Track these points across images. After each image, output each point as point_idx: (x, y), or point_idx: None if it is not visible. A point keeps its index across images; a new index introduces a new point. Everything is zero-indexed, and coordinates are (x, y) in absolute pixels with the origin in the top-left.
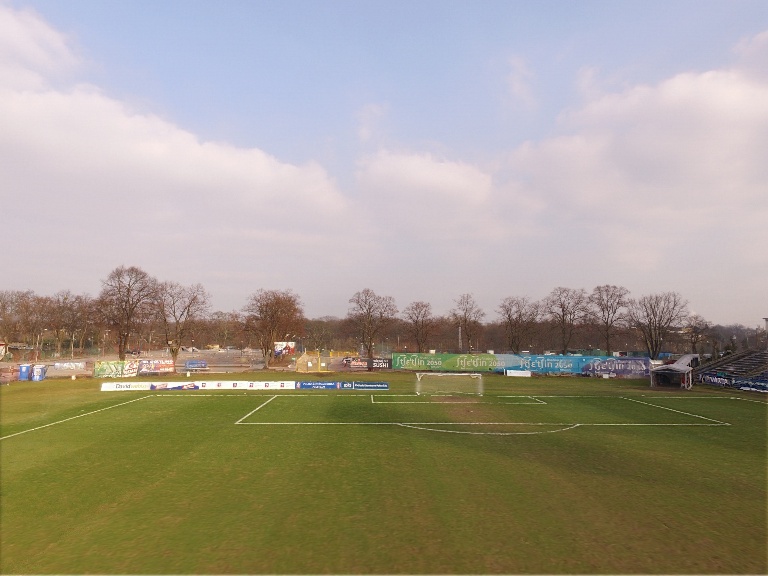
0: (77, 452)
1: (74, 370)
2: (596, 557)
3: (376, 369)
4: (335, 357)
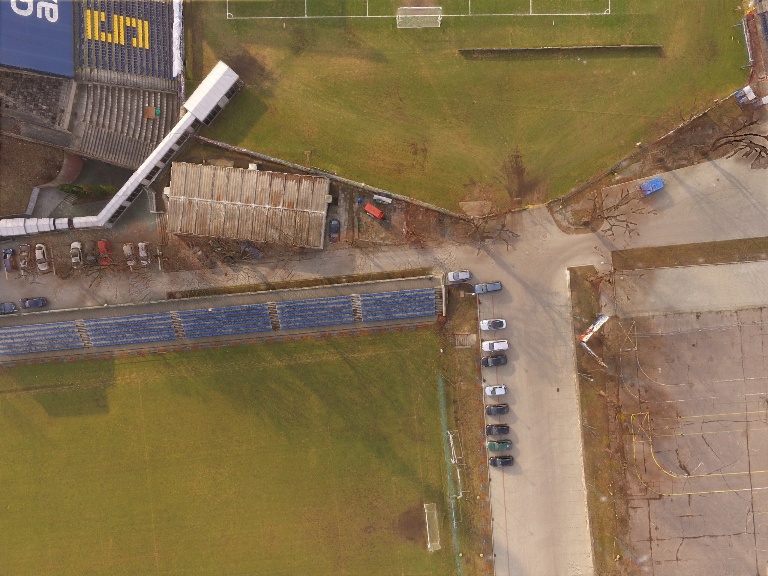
0: None
1: (764, 177)
2: None
3: None
4: None
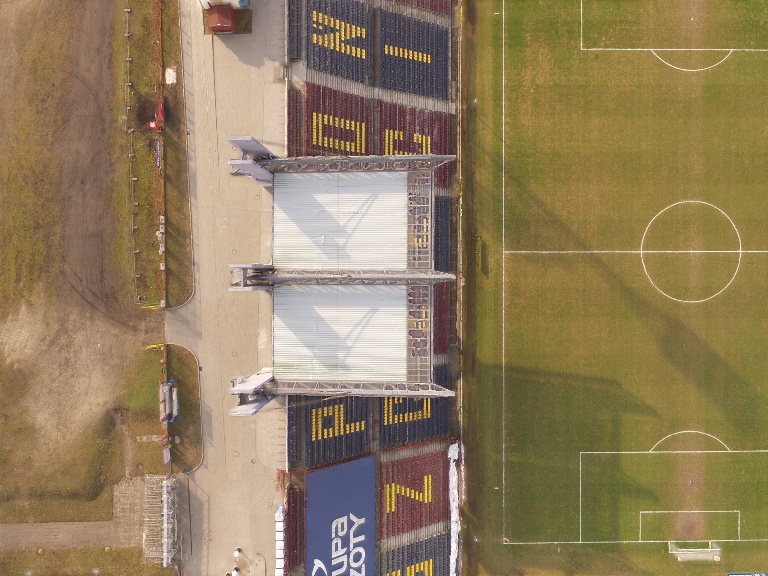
0: None
1: None
2: (705, 332)
3: None
4: None
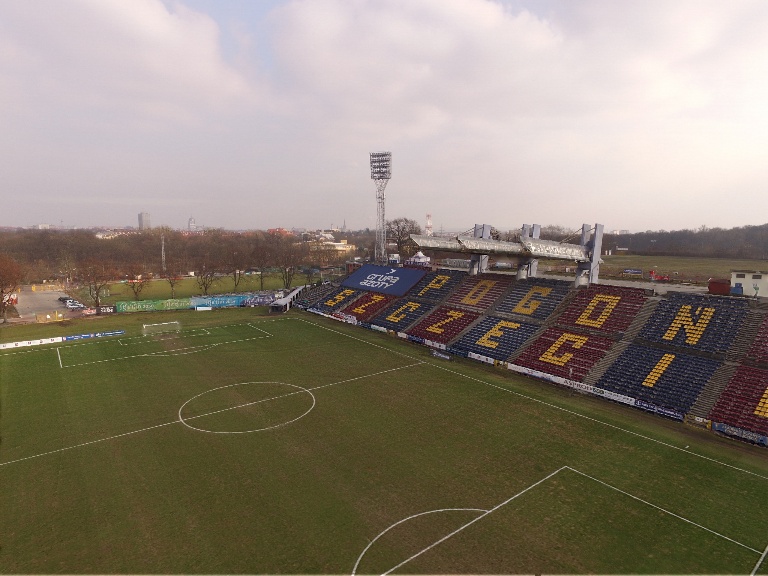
0: (11, 389)
1: None
2: None
3: (104, 314)
4: (40, 292)
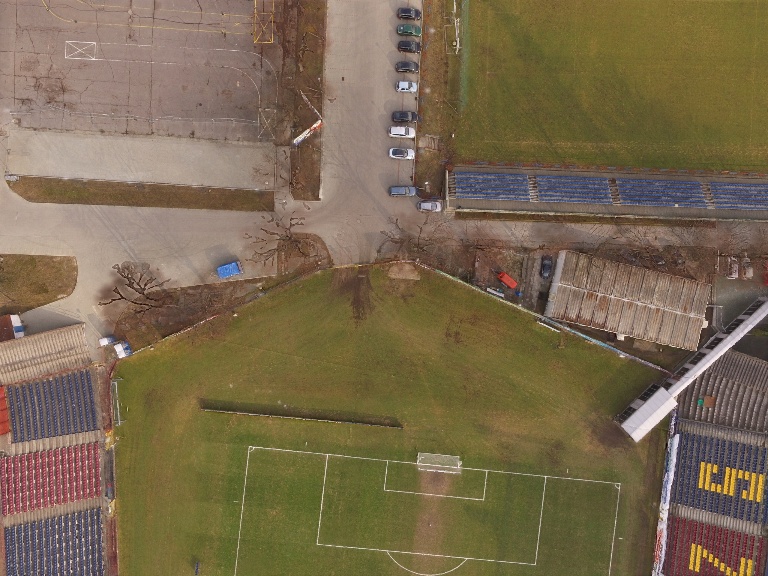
0: None
1: (111, 266)
2: None
3: None
4: None
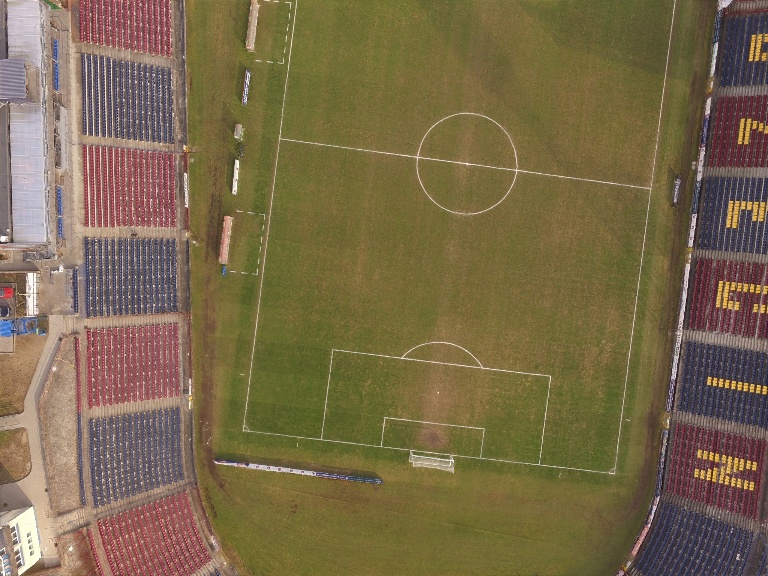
0: None
1: None
2: (464, 81)
3: None
4: None
